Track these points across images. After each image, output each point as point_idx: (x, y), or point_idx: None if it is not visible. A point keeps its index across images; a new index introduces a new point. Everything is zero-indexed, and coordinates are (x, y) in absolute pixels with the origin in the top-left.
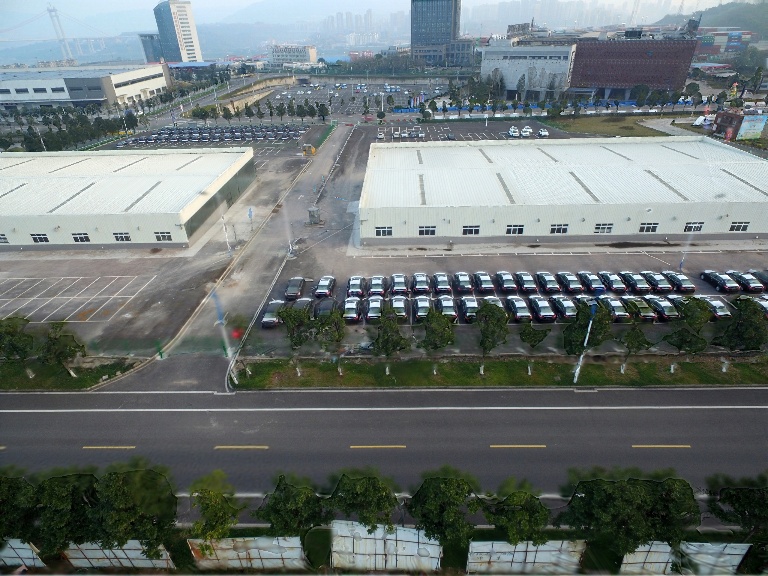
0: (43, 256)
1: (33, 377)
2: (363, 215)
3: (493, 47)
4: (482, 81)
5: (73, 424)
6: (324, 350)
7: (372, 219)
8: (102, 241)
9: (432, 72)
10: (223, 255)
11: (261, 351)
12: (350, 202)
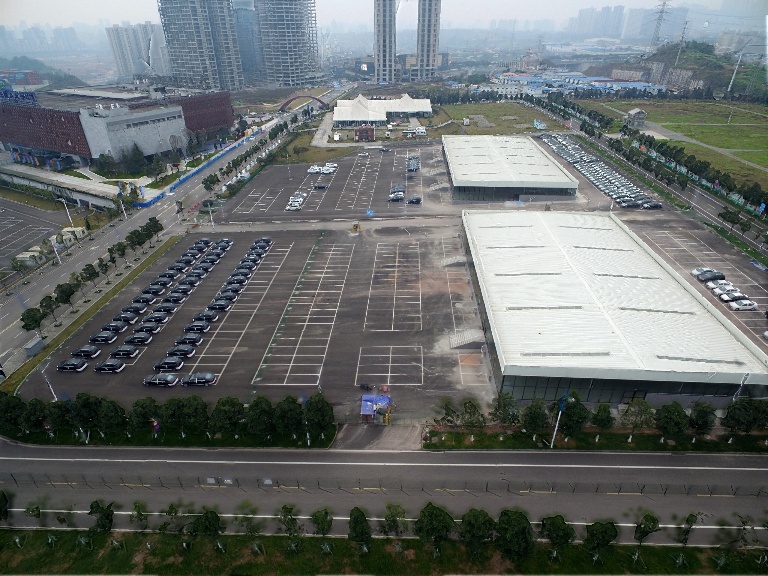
0: None
1: None
2: None
3: (113, 117)
4: (125, 154)
5: None
6: (663, 200)
7: None
8: None
9: None
10: None
11: (673, 207)
12: None
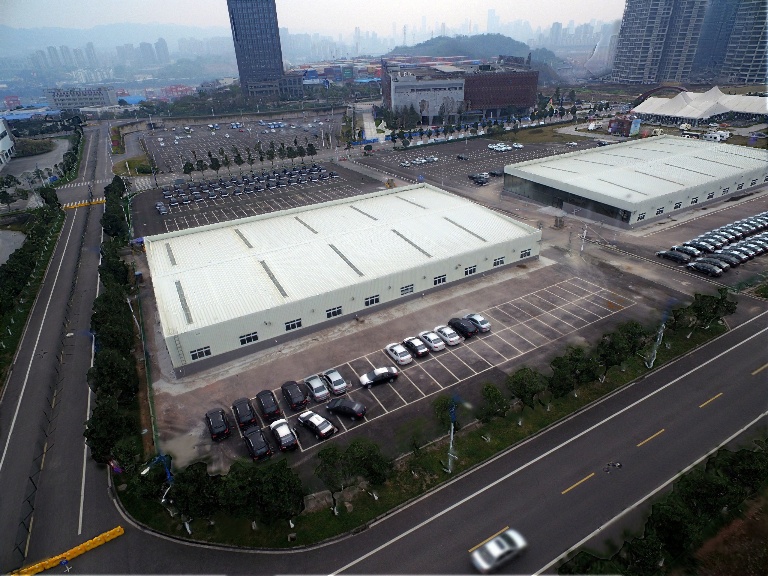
0: (452, 294)
1: (690, 337)
2: (636, 207)
3: (402, 82)
4: (398, 111)
5: (767, 342)
6: None
7: (639, 209)
8: (484, 269)
9: (292, 106)
10: (574, 256)
11: (744, 286)
12: (537, 210)
